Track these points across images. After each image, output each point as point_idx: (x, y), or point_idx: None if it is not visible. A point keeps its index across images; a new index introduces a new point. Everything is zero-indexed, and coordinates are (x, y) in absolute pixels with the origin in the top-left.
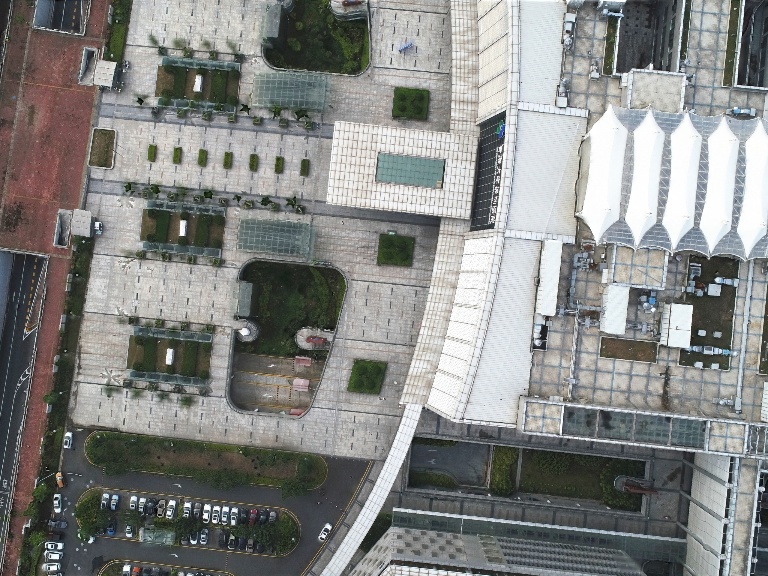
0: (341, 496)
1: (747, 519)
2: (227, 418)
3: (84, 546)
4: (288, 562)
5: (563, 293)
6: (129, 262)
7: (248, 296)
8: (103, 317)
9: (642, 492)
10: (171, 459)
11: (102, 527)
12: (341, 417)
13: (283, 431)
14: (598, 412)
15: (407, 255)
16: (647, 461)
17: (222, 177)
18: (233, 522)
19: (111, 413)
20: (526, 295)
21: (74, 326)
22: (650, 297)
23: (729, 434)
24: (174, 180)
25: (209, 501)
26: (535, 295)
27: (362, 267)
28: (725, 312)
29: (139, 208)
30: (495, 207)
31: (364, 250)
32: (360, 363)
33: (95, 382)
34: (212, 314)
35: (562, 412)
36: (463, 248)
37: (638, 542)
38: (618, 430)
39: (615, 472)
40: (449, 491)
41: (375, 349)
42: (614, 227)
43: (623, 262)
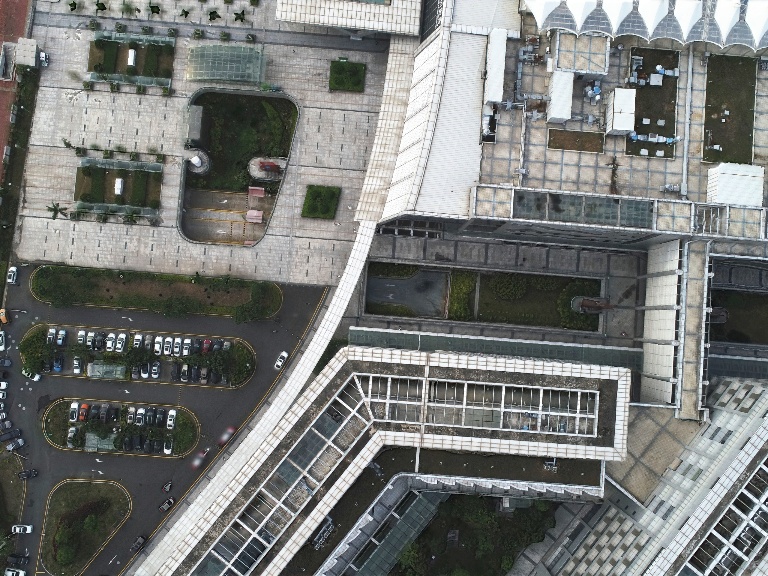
0: (297, 323)
1: (698, 304)
2: (179, 248)
3: (29, 385)
4: (243, 393)
5: (510, 87)
6: (76, 94)
7: (198, 119)
8: (49, 150)
9: (599, 312)
10: (121, 291)
11: (48, 359)
12: (295, 244)
13: (236, 259)
14: (548, 195)
15: (358, 80)
16: (602, 279)
17: (171, 8)
18: (186, 352)
19: (58, 247)
20: (474, 89)
21: (19, 159)
22: (594, 87)
23: (676, 214)
24: (122, 12)
25: (161, 334)
26: (483, 88)
27: (314, 94)
28: (668, 103)
29: (86, 40)
30: (441, 9)
31: (316, 77)
32: (314, 188)
33: (41, 216)
34: (162, 144)
35: (512, 196)
36: (413, 66)
37: (595, 352)
38: (568, 213)
39: (571, 294)
40: (407, 317)
41: (329, 175)
42: (556, 12)
43: (566, 49)
